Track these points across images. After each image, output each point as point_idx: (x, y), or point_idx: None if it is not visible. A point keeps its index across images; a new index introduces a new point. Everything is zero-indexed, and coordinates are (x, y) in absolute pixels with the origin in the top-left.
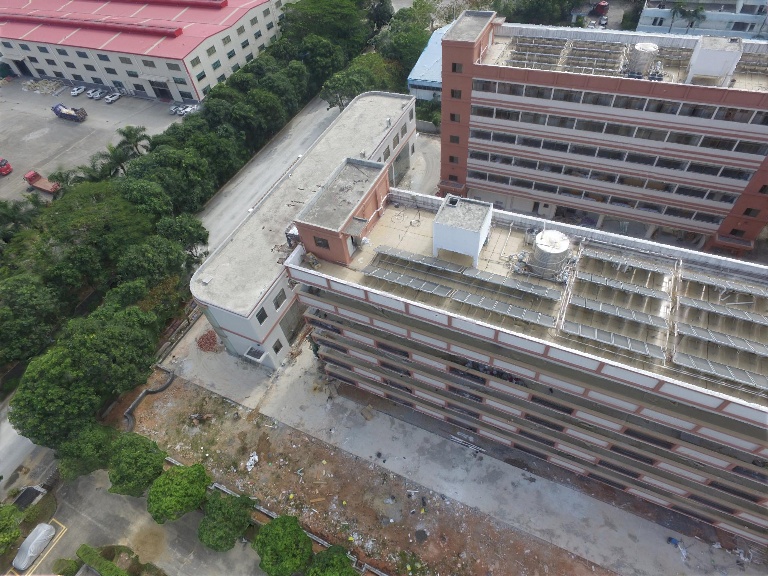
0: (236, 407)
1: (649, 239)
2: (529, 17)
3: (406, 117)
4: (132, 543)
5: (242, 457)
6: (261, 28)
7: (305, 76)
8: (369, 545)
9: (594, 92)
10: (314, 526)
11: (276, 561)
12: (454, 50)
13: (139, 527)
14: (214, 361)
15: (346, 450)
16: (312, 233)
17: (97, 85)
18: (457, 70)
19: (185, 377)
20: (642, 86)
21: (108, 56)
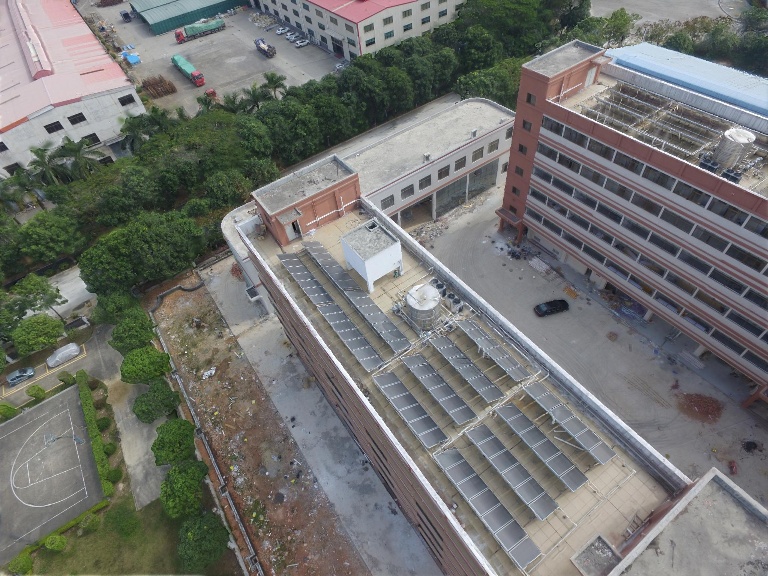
0: (225, 328)
1: (696, 357)
2: (752, 58)
3: (500, 134)
4: (111, 386)
5: (205, 366)
6: (448, 7)
7: (453, 65)
8: (240, 480)
9: (656, 169)
10: (215, 443)
11: (162, 448)
12: (531, 80)
13: (120, 378)
14: (234, 286)
15: (273, 402)
16: (261, 209)
17: (298, 29)
18: (531, 101)
19: (209, 288)
20: (708, 179)
21: (309, 6)
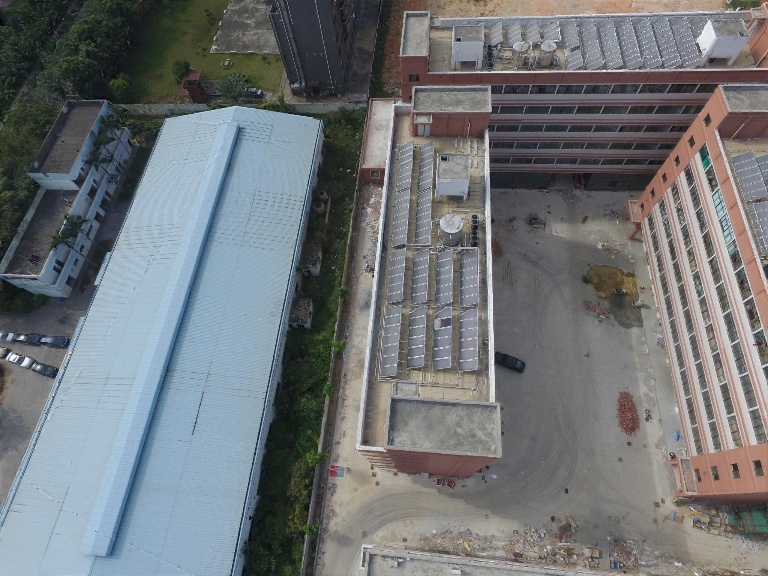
0: None
1: None
2: None
3: None
4: None
5: None
6: None
7: None
8: None
9: None
10: None
11: None
12: None
13: None
14: None
15: None
16: None
17: None
18: None
19: None
20: None
21: None
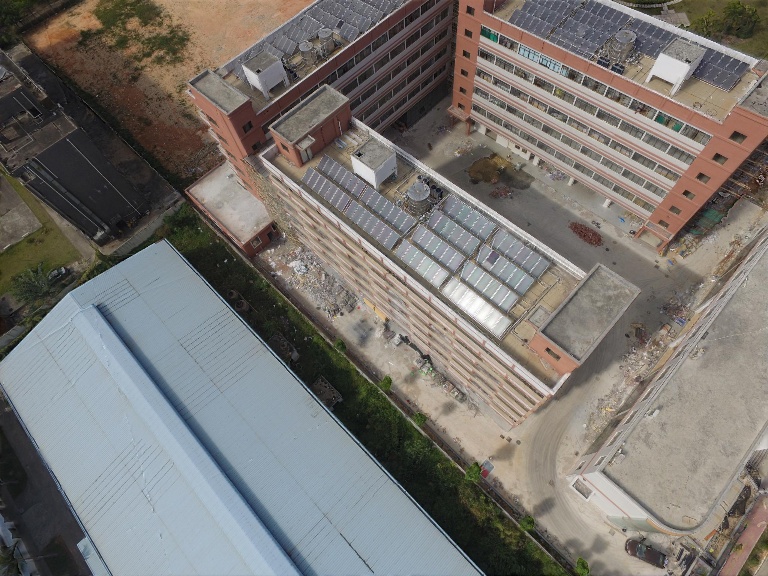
0: None
1: None
2: None
3: None
4: None
5: None
6: None
7: None
8: None
9: None
10: None
11: None
12: None
13: None
14: None
15: None
16: None
17: None
18: None
19: None
20: None
21: None
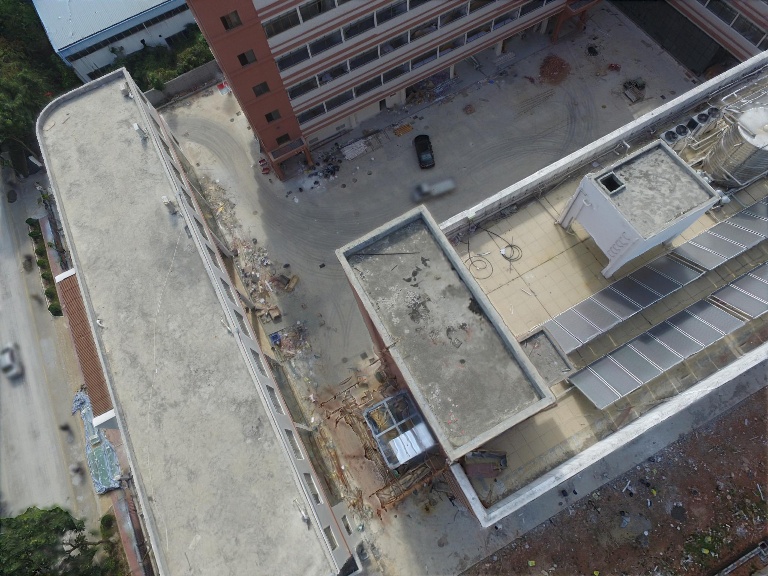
0: None
1: (502, 55)
2: None
3: None
4: None
5: None
6: None
7: None
8: None
9: None
10: None
11: None
12: None
13: None
14: None
15: (534, 527)
16: None
17: None
18: None
19: None
20: None
21: None
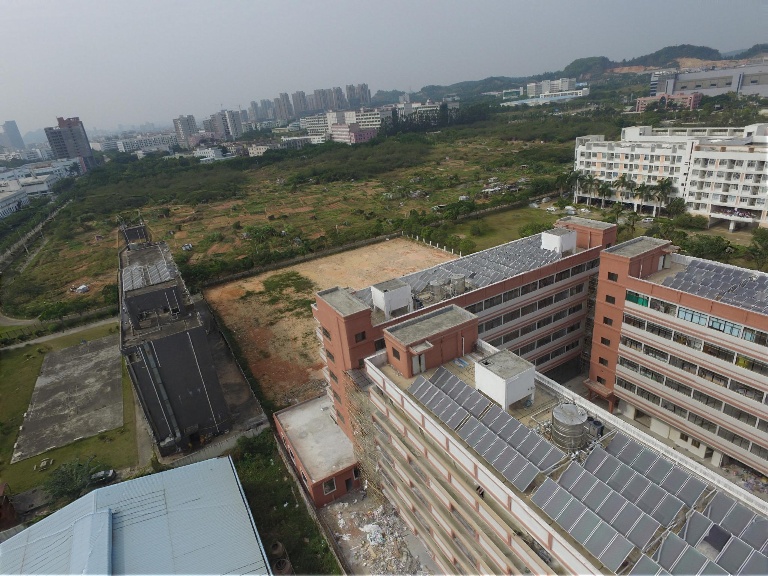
0: None
1: None
2: None
3: None
4: None
5: None
6: None
7: None
8: None
9: None
10: None
11: None
12: None
13: None
14: None
15: None
16: None
17: None
18: None
19: None
20: None
21: None
